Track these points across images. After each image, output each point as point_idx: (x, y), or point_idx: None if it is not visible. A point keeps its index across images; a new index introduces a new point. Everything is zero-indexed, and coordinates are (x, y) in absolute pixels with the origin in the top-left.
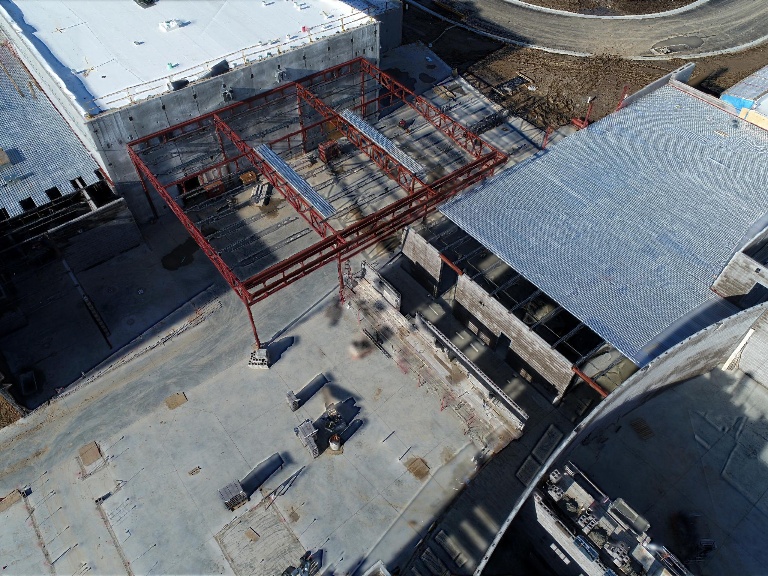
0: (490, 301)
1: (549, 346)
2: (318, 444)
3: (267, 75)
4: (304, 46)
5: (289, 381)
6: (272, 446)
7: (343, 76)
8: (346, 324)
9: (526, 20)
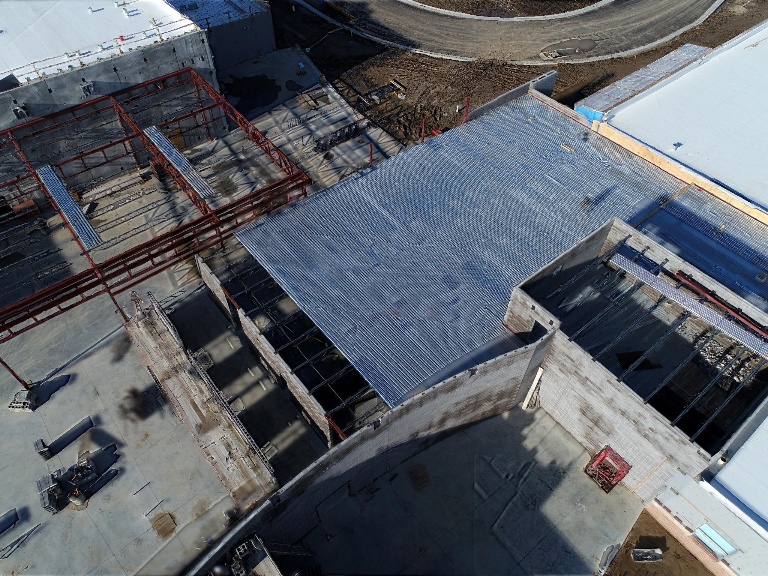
0: (261, 339)
1: (306, 391)
2: (62, 498)
3: (70, 89)
4: (112, 58)
5: (51, 426)
6: (11, 501)
7: None
8: (131, 360)
9: (417, 22)
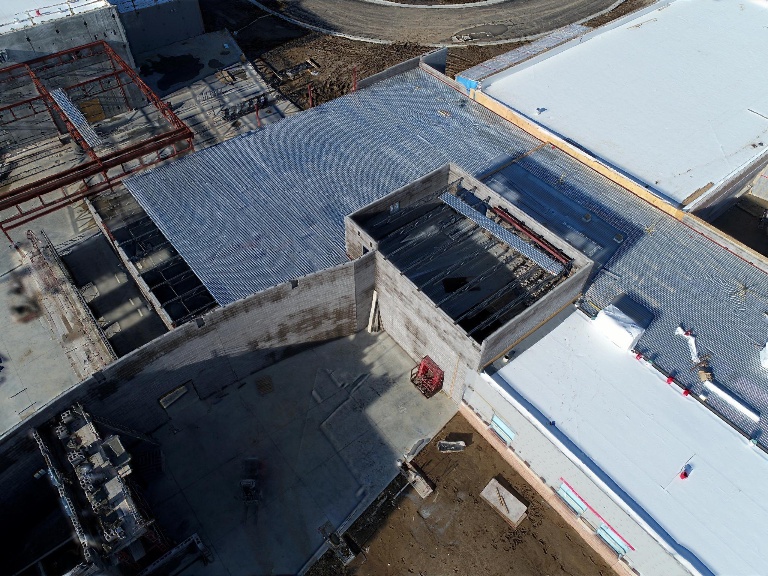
0: (130, 266)
1: (159, 305)
2: None
3: None
4: (25, 28)
5: None
6: None
7: (85, 59)
8: (26, 291)
9: (344, 9)
